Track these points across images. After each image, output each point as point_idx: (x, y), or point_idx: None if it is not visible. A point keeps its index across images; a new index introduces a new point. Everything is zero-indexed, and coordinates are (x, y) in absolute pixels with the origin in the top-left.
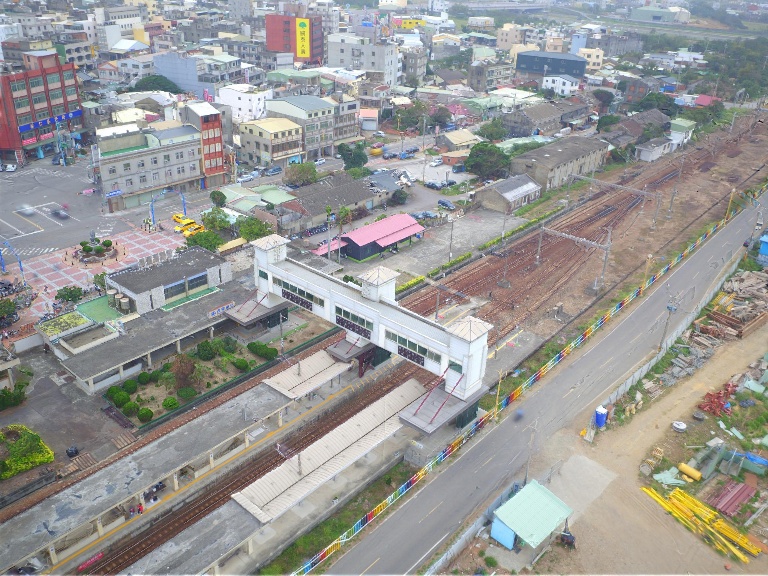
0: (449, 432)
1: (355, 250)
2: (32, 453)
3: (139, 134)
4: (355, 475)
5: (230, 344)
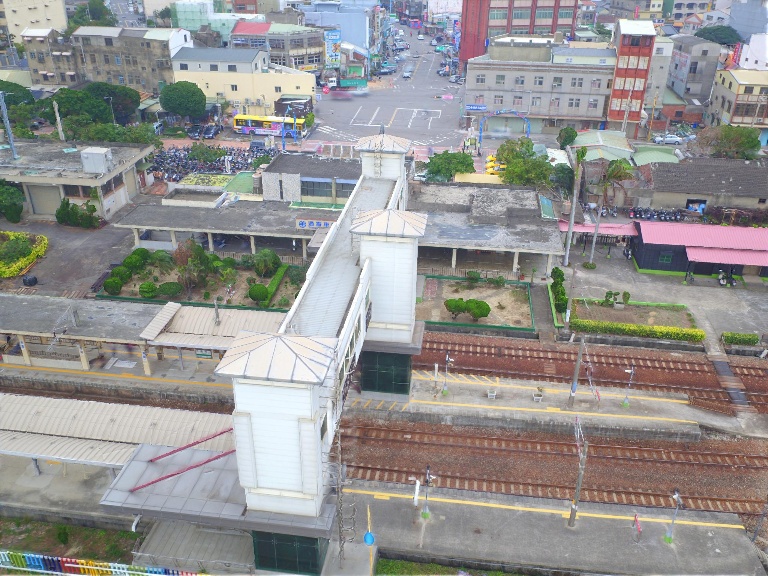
0: (247, 556)
1: (640, 248)
2: (1, 260)
3: (545, 48)
4: (60, 490)
5: (297, 271)
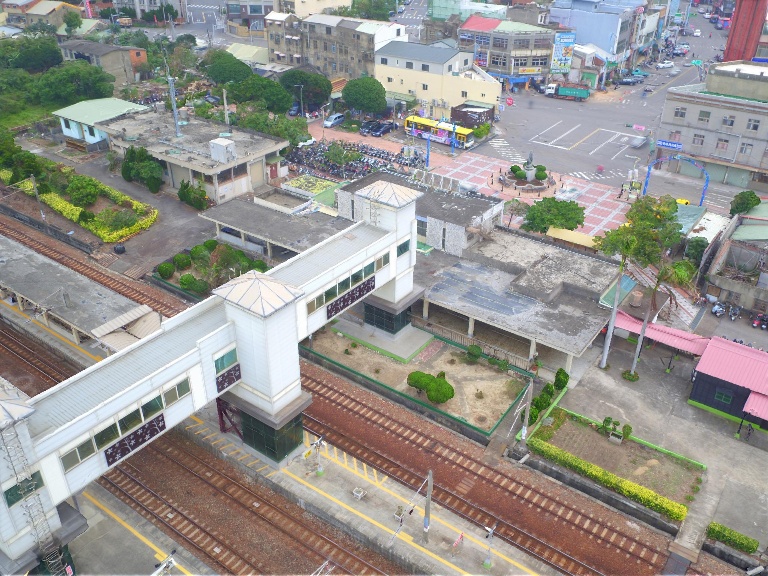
0: None
1: None
2: (108, 226)
3: None
4: None
5: None
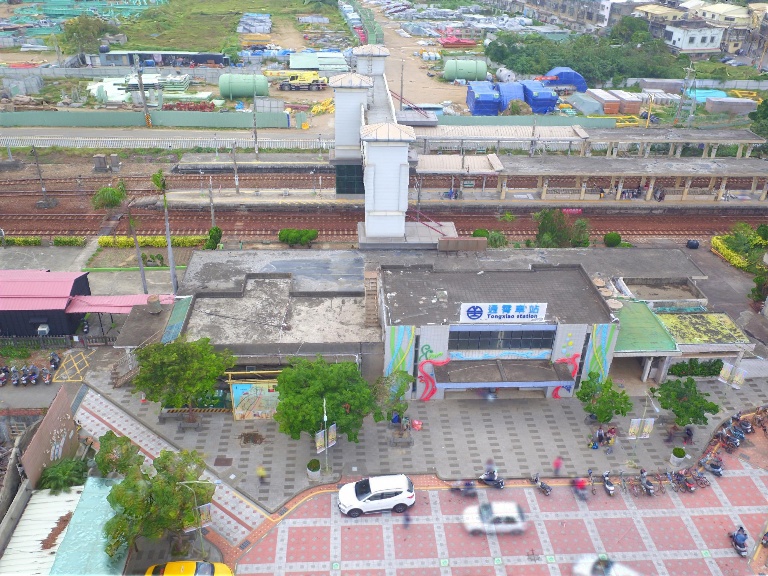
0: None
1: (85, 292)
2: None
3: None
4: None
5: None
